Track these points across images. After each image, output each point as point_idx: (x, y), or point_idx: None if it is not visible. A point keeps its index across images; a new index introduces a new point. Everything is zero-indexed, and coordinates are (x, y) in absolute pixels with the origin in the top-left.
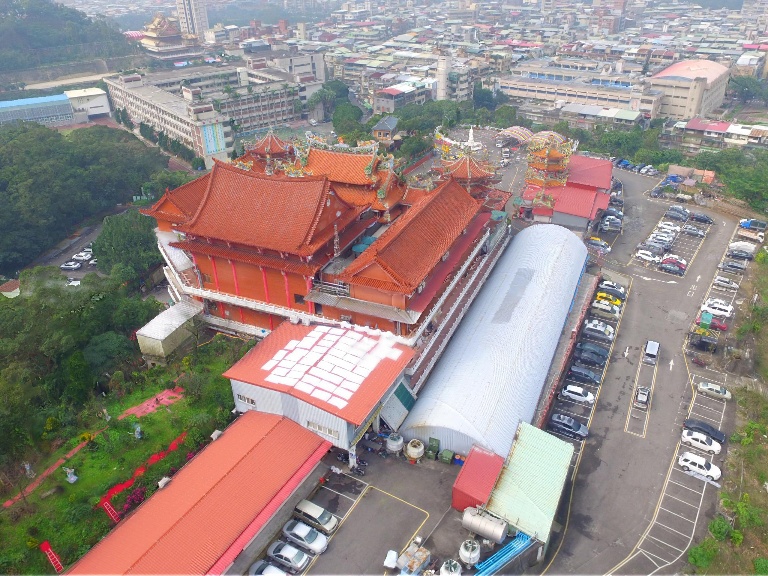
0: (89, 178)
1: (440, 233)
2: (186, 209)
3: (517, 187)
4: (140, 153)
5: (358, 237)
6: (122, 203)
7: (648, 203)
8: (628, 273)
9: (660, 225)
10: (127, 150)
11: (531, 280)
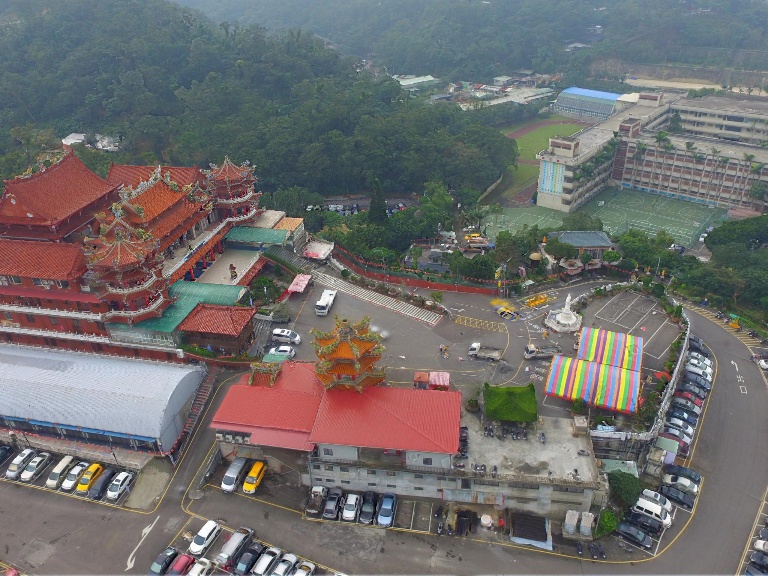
0: (398, 162)
1: (1, 263)
2: (111, 179)
3: (385, 371)
4: (462, 161)
5: (38, 240)
6: (418, 193)
7: None
8: (163, 509)
9: (337, 574)
10: (457, 154)
11: (45, 369)
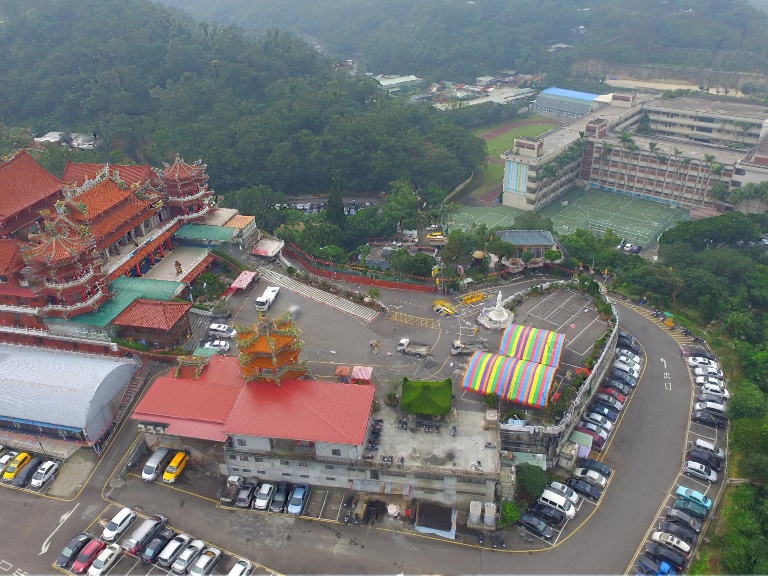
0: (366, 161)
1: None
2: (67, 177)
3: (313, 366)
4: (429, 160)
5: None
6: (386, 192)
7: (372, 568)
8: (84, 496)
9: None
10: (425, 154)
11: None
